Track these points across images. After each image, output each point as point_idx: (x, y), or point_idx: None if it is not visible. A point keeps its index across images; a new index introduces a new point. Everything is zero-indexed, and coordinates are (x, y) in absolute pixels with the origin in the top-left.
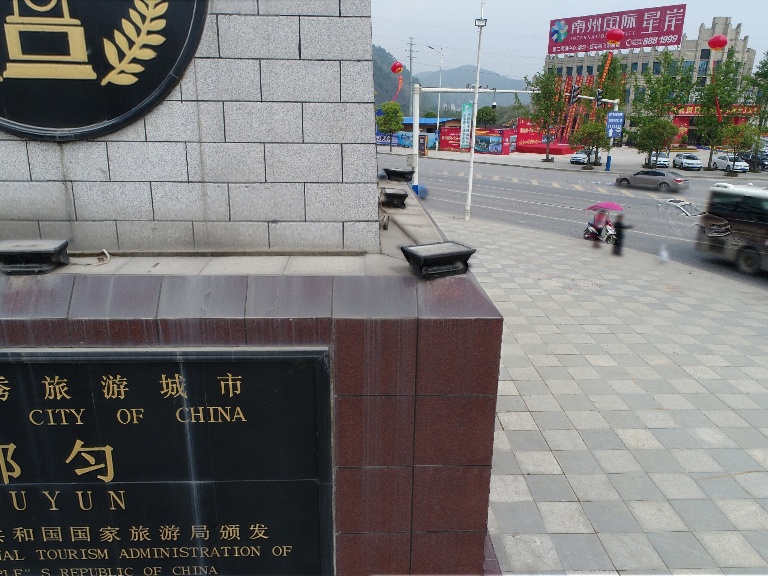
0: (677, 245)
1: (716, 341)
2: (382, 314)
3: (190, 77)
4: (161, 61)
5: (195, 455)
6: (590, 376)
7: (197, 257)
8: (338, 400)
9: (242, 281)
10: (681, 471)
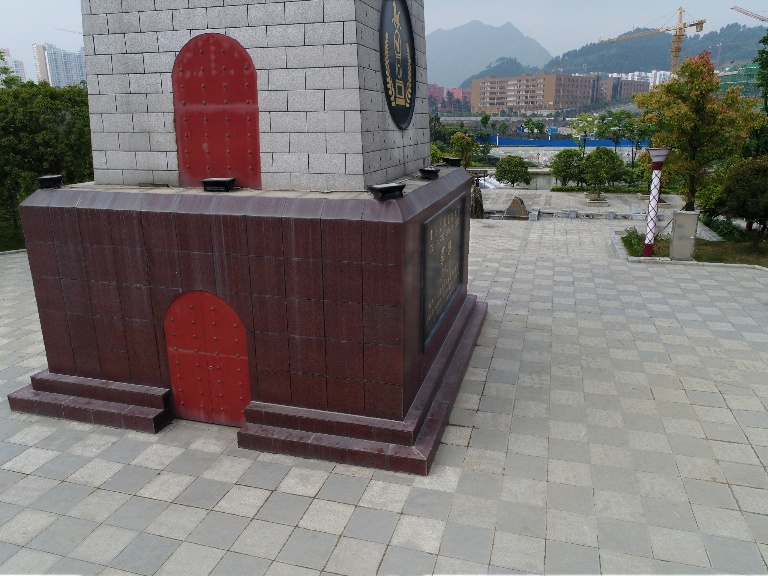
0: None
1: None
2: None
3: None
4: None
5: None
6: None
7: None
8: None
9: None
10: None
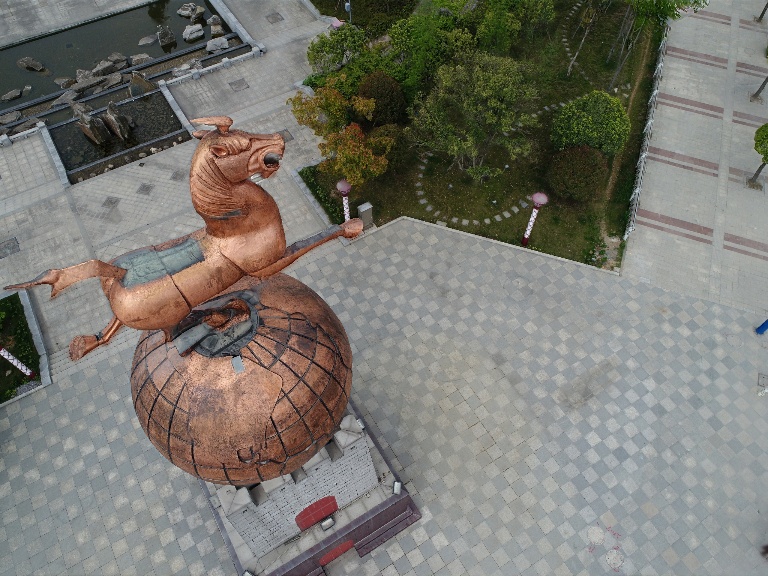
0: None
1: None
2: None
3: None
4: None
5: None
6: None
7: None
8: None
9: (230, 543)
10: None
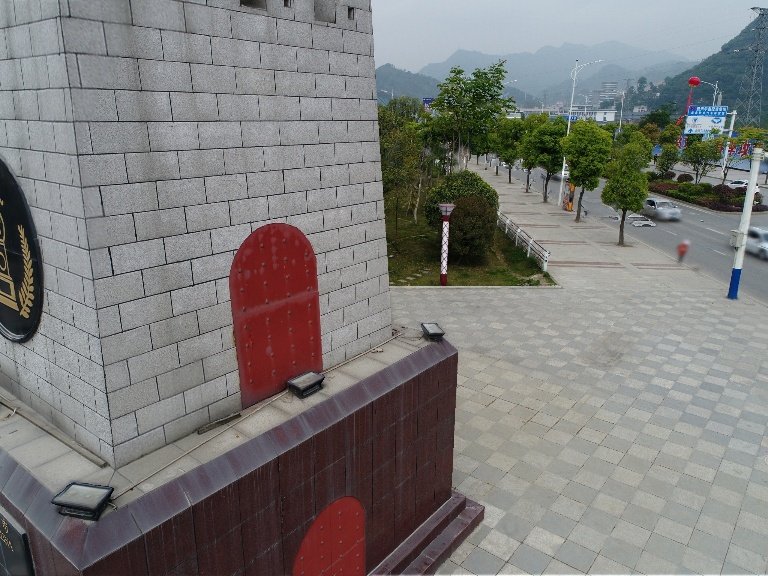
0: None
1: None
2: (40, 527)
3: (42, 322)
4: (34, 309)
5: (4, 556)
6: None
7: (42, 431)
8: (36, 568)
9: (14, 466)
10: None
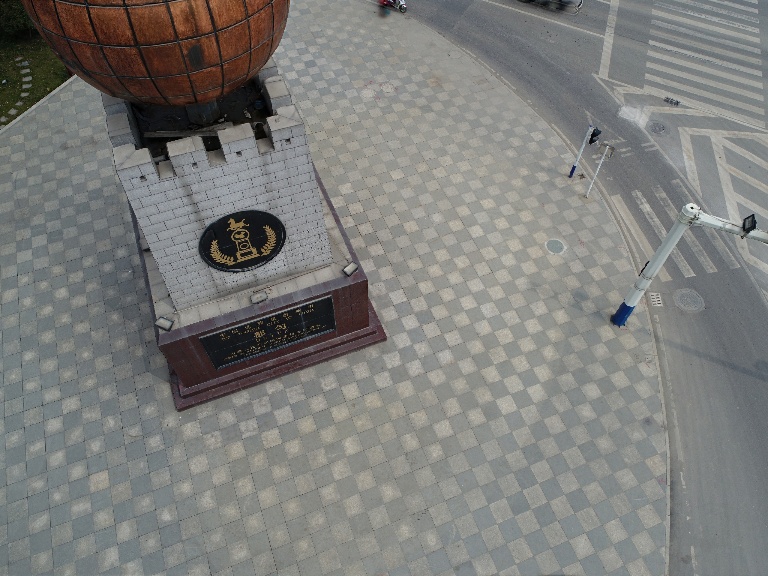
0: (447, 2)
1: (450, 141)
2: (342, 286)
3: (283, 248)
4: None
5: None
6: (392, 189)
7: (291, 280)
8: None
9: (309, 289)
10: (424, 241)
